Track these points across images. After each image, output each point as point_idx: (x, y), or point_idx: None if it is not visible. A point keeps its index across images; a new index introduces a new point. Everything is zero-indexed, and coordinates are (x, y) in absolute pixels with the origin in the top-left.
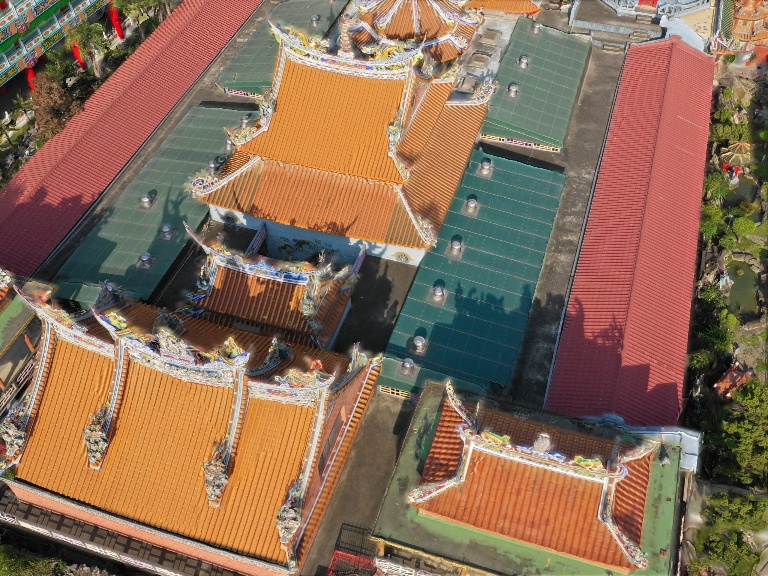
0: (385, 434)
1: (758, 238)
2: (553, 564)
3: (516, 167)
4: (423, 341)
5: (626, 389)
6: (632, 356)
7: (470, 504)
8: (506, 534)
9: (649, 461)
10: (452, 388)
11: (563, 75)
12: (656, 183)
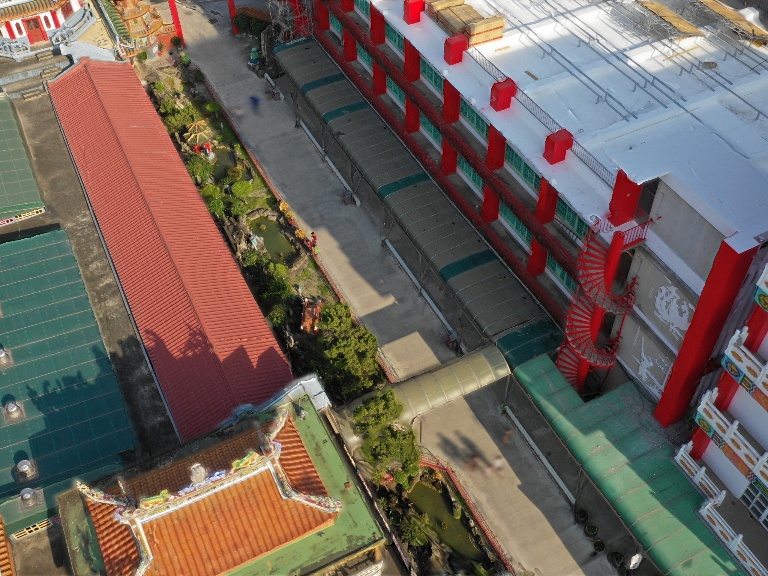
0: (49, 575)
1: (258, 192)
2: (274, 564)
3: (11, 248)
4: (28, 463)
5: (237, 378)
6: (224, 348)
7: (172, 573)
8: (220, 572)
9: (291, 423)
10: (85, 486)
11: (1, 140)
12: (149, 193)
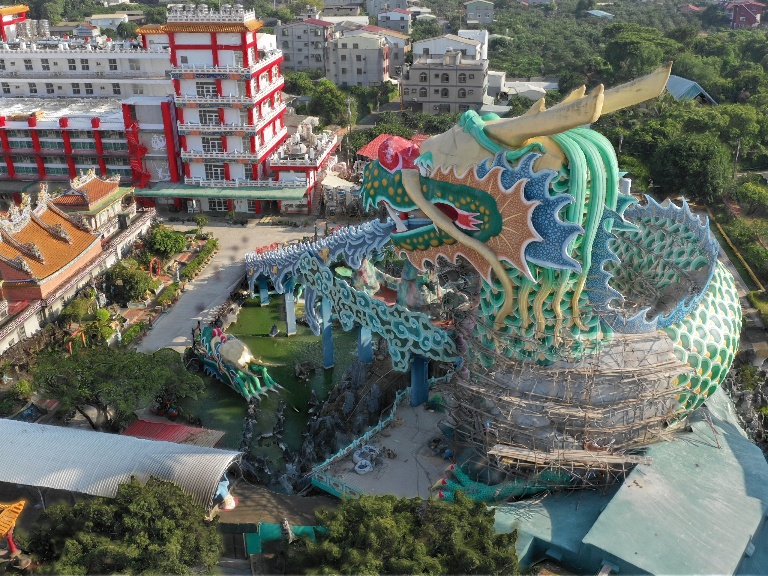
0: None
1: None
2: None
3: None
4: None
5: None
6: None
7: None
8: None
9: None
10: None
11: None
12: None
